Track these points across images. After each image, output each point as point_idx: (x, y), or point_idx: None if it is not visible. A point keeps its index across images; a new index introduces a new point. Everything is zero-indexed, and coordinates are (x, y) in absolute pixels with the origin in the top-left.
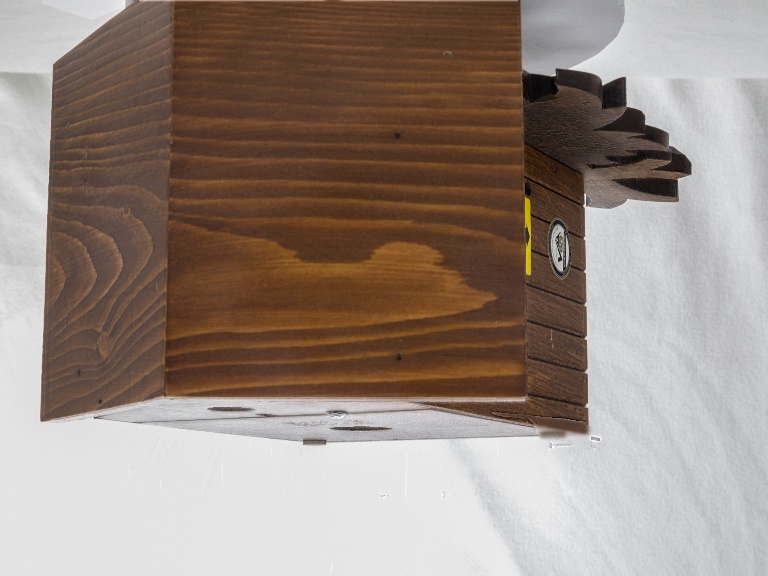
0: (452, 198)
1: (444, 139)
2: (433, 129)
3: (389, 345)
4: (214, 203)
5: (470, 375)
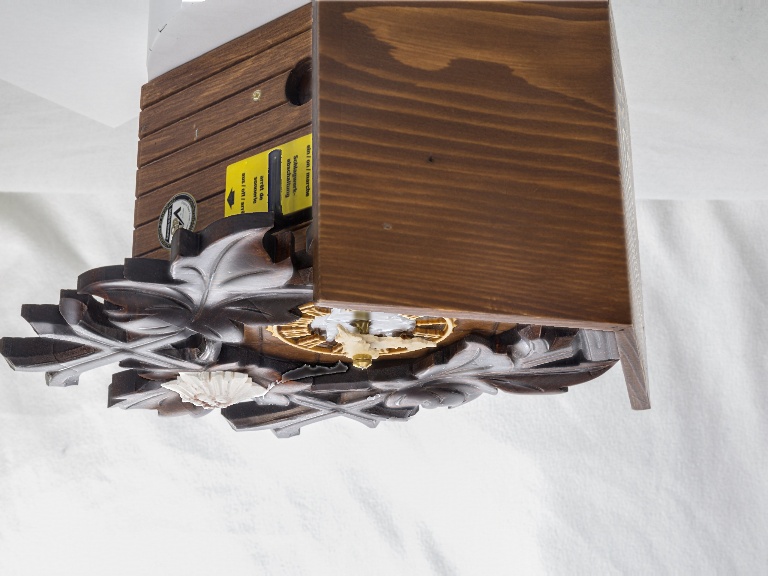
0: (383, 100)
1: (390, 151)
2: (400, 161)
3: None
4: (582, 121)
5: None
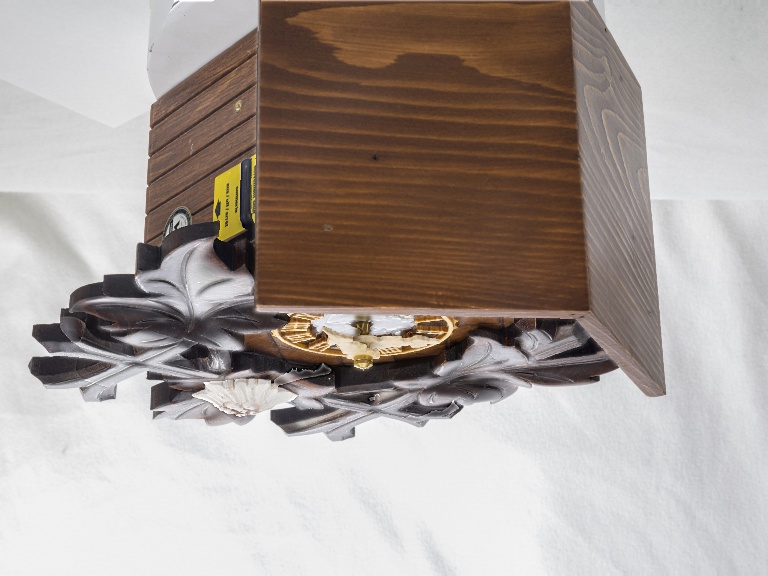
0: (325, 102)
1: (332, 153)
2: (342, 162)
3: None
4: (537, 107)
5: None
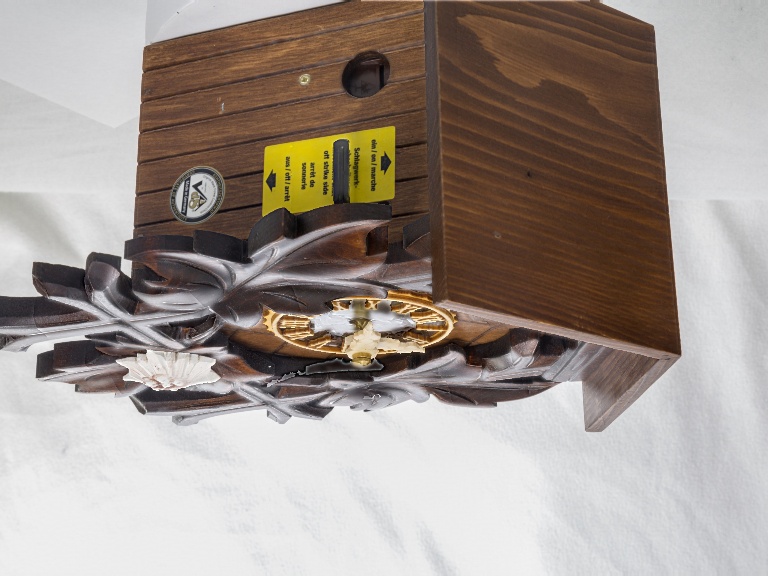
0: (490, 109)
1: (498, 161)
2: (505, 172)
3: (526, 9)
4: (640, 157)
5: None
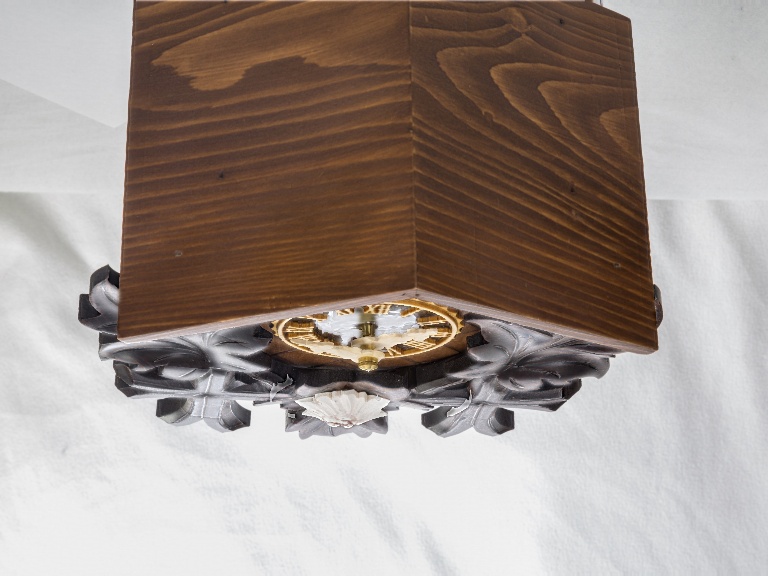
0: (181, 132)
1: (185, 180)
2: (193, 187)
3: (233, 7)
4: (373, 87)
5: (174, 0)
